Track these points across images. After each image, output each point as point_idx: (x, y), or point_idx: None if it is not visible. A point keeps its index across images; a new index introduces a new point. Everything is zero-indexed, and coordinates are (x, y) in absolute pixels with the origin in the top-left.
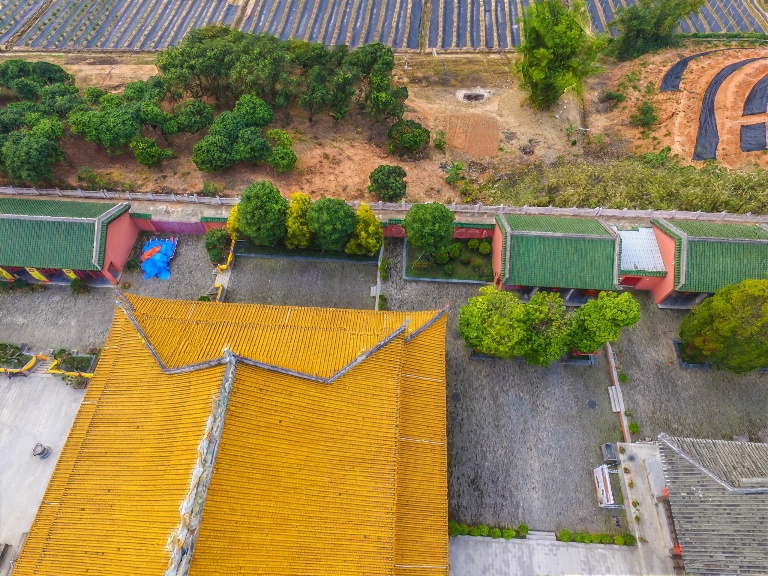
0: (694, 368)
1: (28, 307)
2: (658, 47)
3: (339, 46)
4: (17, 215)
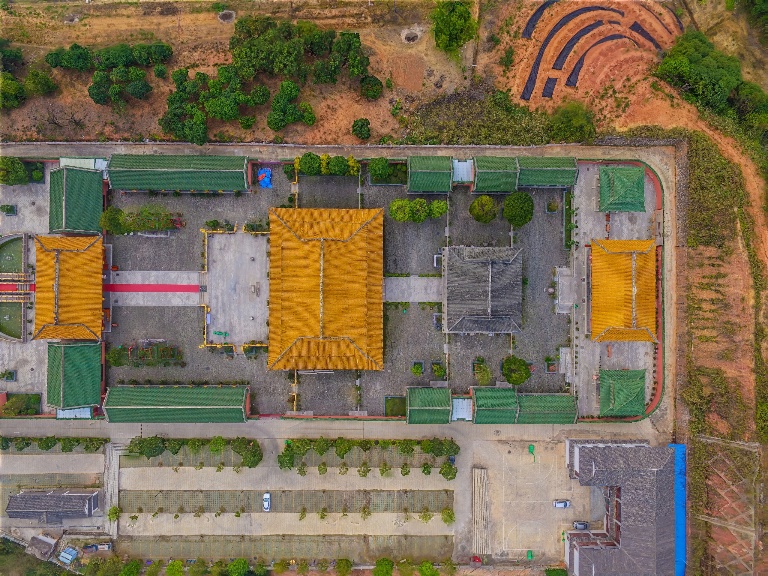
0: None
1: (220, 204)
2: None
3: (329, 33)
4: (210, 170)
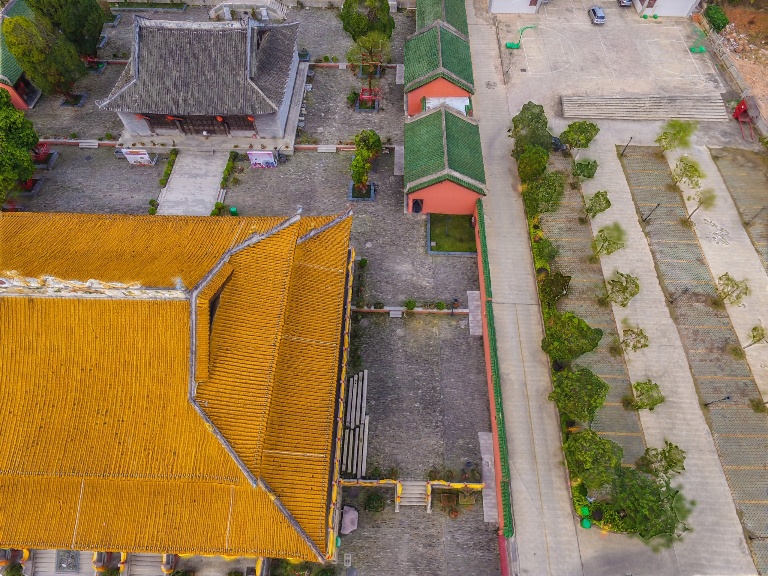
0: (84, 101)
1: None
2: None
3: None
4: None
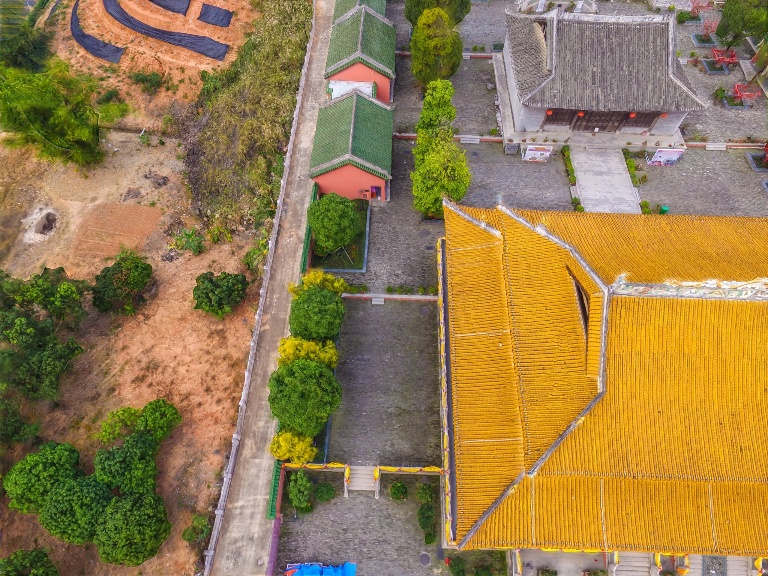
0: None
1: None
2: (45, 50)
3: None
4: None
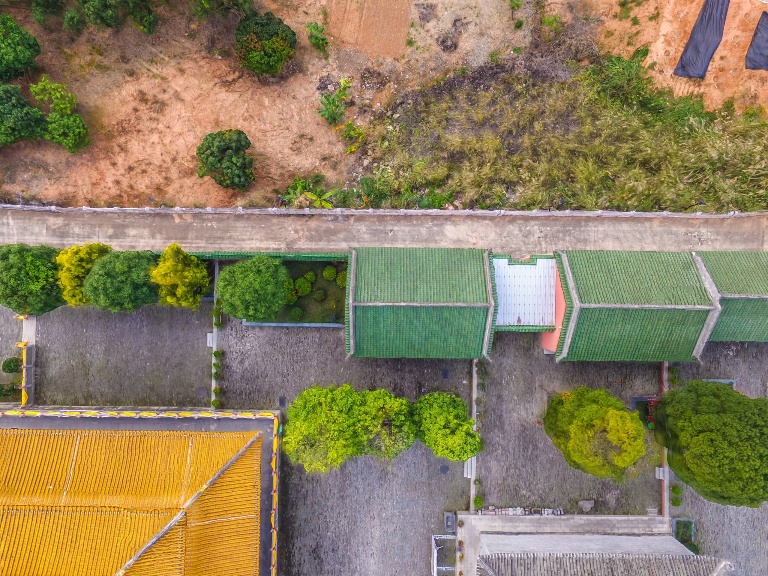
0: None
1: None
2: None
3: None
4: None
